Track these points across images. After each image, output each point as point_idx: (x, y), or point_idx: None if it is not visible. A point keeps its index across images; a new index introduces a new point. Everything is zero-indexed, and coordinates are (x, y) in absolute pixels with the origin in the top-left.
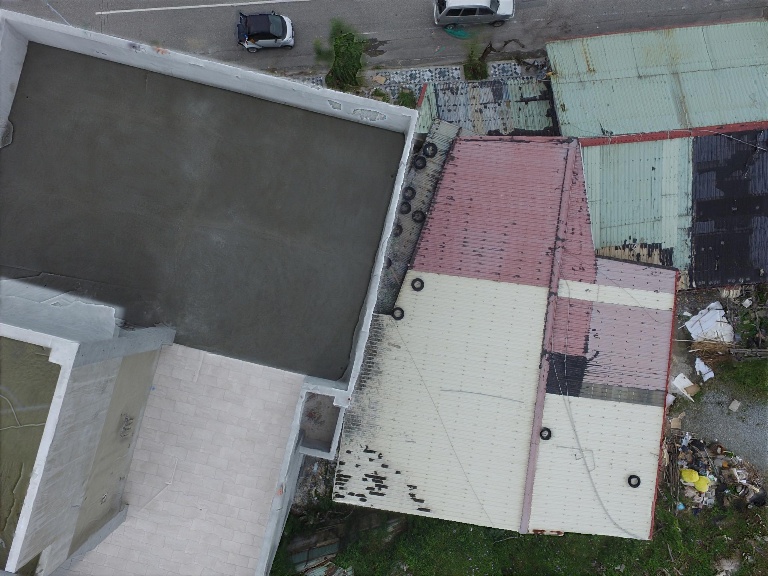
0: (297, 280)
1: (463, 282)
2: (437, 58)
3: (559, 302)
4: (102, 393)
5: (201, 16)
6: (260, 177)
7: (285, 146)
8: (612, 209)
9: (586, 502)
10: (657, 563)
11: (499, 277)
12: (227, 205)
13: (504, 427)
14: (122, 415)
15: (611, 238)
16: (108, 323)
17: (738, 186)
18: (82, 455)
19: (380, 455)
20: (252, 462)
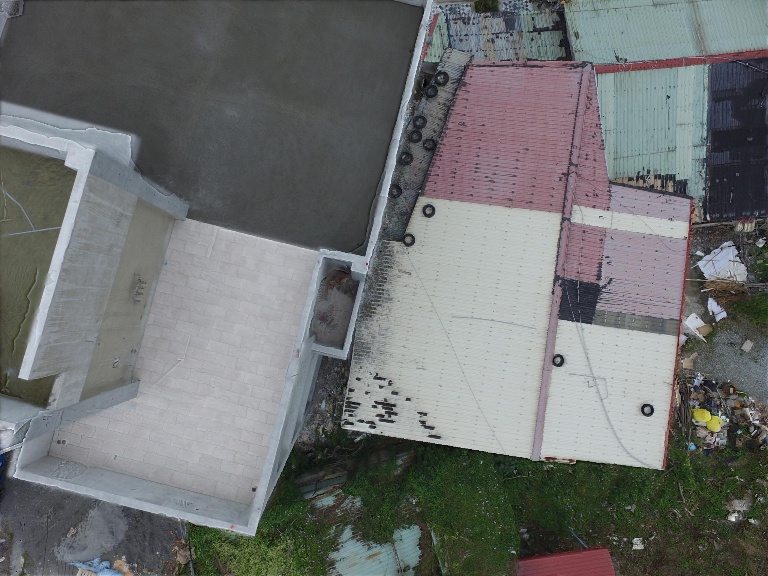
0: (313, 156)
1: (475, 208)
2: None
3: (572, 228)
4: (117, 226)
5: None
6: (275, 51)
7: (301, 20)
8: (626, 139)
9: (599, 430)
10: (668, 503)
11: (511, 203)
12: (242, 79)
13: (516, 354)
14: (135, 275)
15: (624, 169)
16: (124, 150)
17: (754, 115)
18: (96, 287)
19: (390, 382)
20: (266, 339)
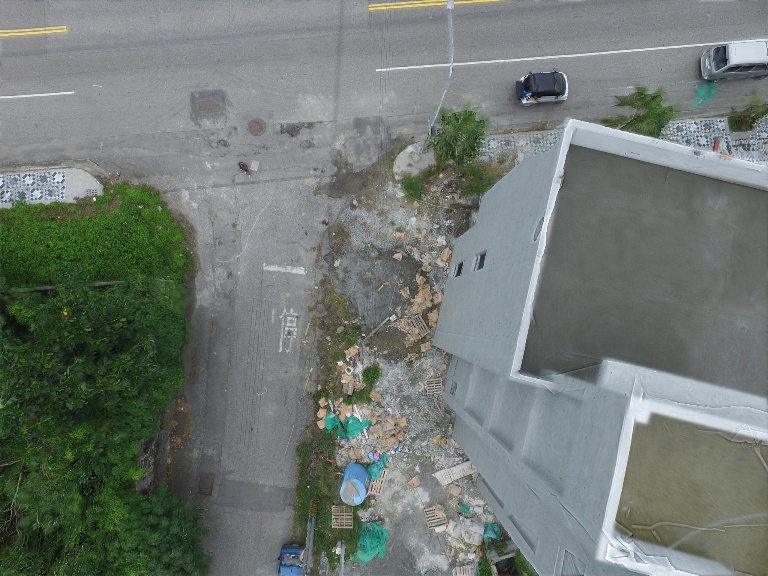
0: None
1: None
2: (700, 110)
3: None
4: None
5: (475, 72)
6: None
7: None
8: None
9: None
10: None
11: None
12: (748, 293)
13: None
14: None
15: None
16: None
17: None
18: None
19: None
20: None
